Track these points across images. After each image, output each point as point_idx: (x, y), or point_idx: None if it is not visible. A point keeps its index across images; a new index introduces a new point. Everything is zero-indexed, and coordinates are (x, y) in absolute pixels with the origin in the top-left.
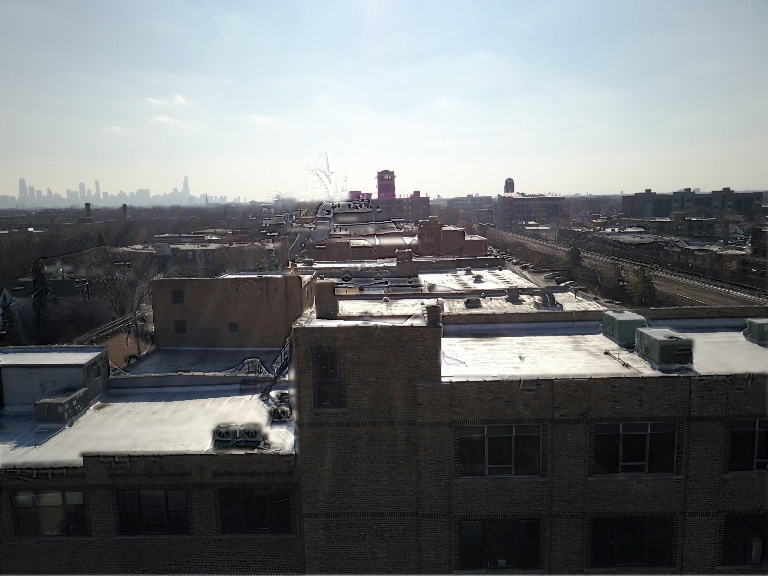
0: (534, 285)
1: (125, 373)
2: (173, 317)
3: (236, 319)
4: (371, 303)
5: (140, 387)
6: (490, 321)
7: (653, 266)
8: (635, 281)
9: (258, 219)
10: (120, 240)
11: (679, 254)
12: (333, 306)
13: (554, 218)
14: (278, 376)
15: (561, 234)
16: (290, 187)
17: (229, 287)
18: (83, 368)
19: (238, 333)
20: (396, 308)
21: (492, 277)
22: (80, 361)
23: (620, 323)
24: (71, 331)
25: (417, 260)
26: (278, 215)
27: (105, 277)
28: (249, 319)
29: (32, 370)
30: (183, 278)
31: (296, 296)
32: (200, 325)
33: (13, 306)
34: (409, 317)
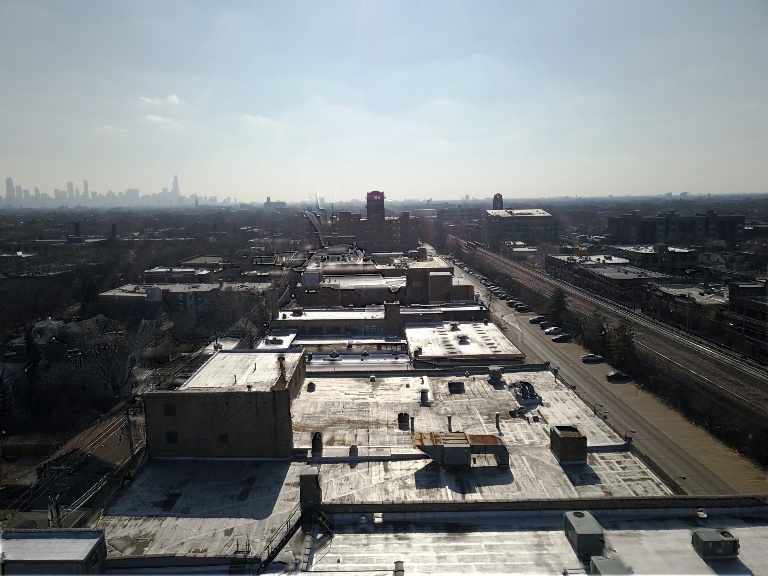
0: (517, 350)
1: (121, 554)
2: (165, 429)
3: (226, 431)
4: (357, 384)
5: (135, 568)
6: (462, 509)
7: (635, 311)
8: (615, 338)
9: (248, 257)
10: (110, 281)
11: (660, 298)
12: (316, 496)
13: (541, 246)
14: (265, 567)
15: (547, 262)
16: (279, 229)
17: (219, 401)
18: (82, 564)
19: (227, 444)
20: (381, 393)
21: (477, 335)
22: (79, 556)
23: (578, 536)
24: (63, 403)
25: (404, 313)
26: (268, 256)
27: (97, 347)
28: (238, 431)
29: (33, 566)
30: (174, 392)
31: (284, 409)
32: (191, 436)
33: (6, 381)
34: (387, 505)
